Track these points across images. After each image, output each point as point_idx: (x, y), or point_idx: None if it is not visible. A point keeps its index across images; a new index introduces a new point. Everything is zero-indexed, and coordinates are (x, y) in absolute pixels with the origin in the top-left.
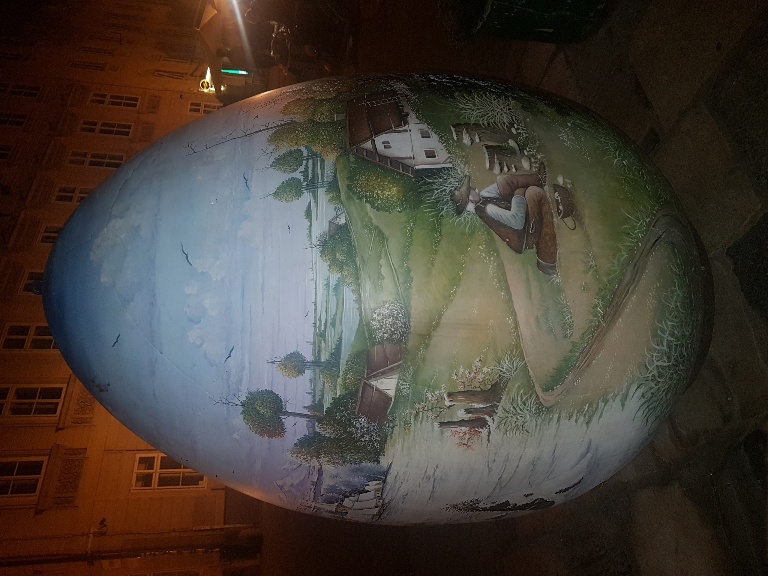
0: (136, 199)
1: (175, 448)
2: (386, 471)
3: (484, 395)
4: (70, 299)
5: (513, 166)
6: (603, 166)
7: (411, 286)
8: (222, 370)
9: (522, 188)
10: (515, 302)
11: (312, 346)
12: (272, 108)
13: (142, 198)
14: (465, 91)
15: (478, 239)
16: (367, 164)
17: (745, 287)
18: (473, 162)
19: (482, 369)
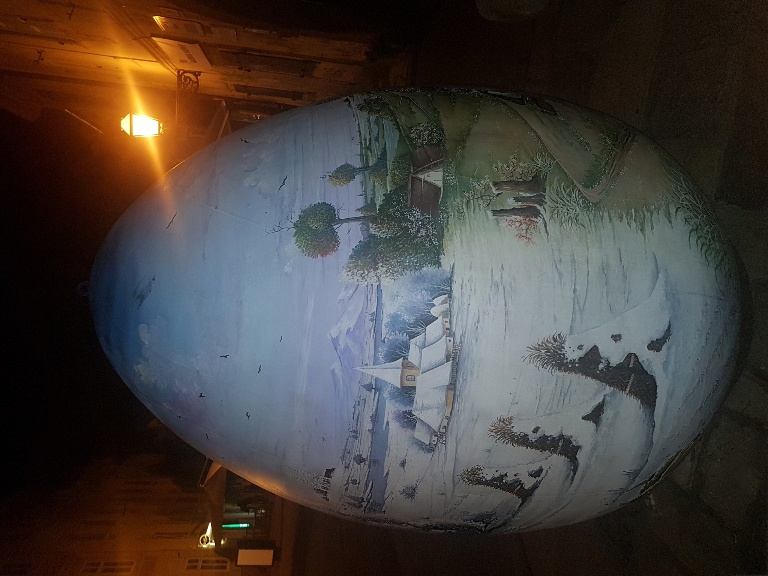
0: None
1: (215, 338)
2: (450, 278)
3: (528, 185)
4: (128, 227)
5: None
6: None
7: (439, 115)
8: (276, 198)
9: None
10: (531, 125)
11: (360, 157)
12: None
13: None
14: None
15: (487, 99)
16: None
17: (744, 203)
18: None
19: (519, 164)
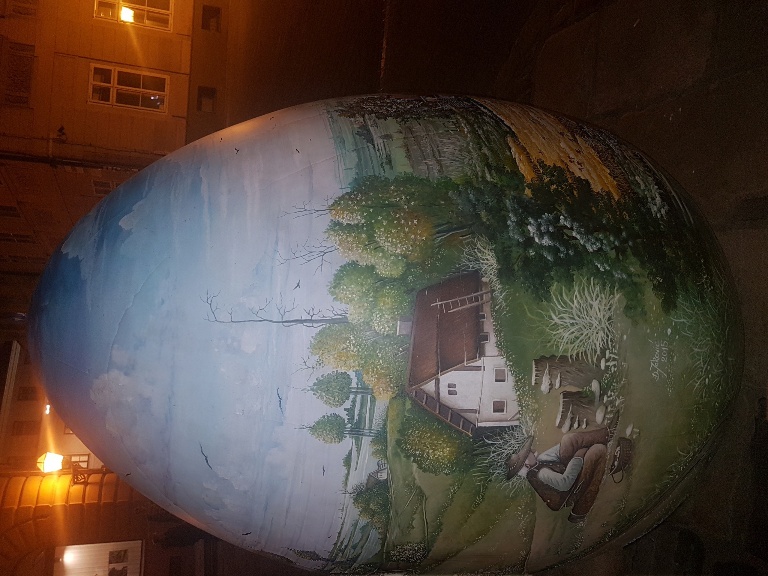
0: (143, 359)
1: None
2: None
3: None
4: (69, 408)
5: (585, 421)
6: (682, 398)
7: (439, 535)
8: (237, 536)
9: (585, 448)
10: (534, 543)
11: (329, 553)
12: (319, 272)
13: (150, 362)
14: (566, 278)
15: (519, 501)
16: (424, 416)
17: (757, 442)
18: (543, 418)
19: (483, 572)
